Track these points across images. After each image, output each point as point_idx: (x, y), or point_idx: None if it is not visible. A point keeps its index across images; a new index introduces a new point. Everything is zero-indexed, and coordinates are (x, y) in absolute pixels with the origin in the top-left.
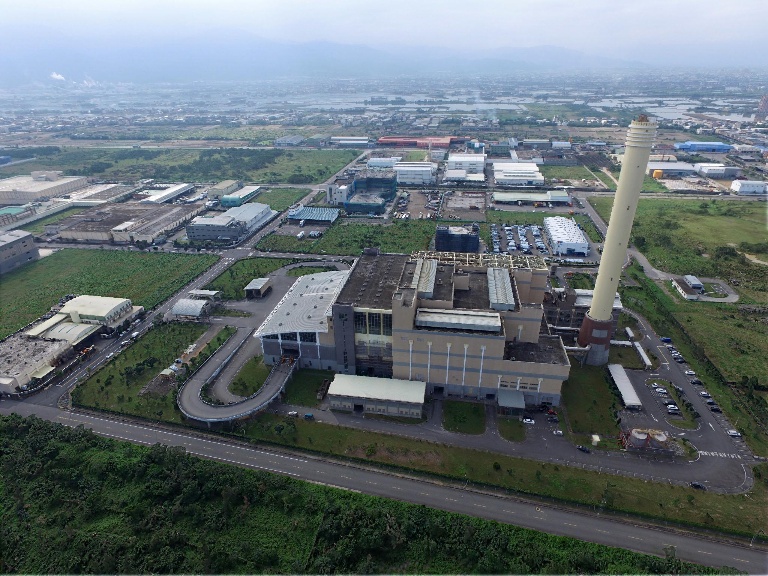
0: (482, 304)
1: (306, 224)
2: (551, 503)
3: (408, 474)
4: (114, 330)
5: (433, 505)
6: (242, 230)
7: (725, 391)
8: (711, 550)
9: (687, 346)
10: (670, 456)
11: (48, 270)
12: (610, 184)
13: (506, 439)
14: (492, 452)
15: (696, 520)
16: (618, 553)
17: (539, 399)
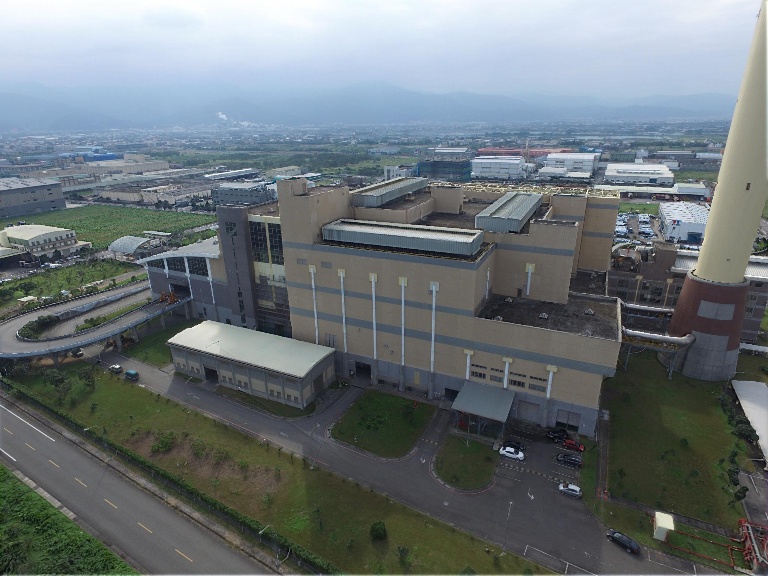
0: (466, 226)
1: None
2: None
3: (190, 503)
4: (38, 259)
5: None
6: (267, 197)
7: None
8: None
9: None
10: None
11: (57, 216)
12: None
13: (441, 478)
14: (393, 498)
15: None
16: None
17: (550, 414)
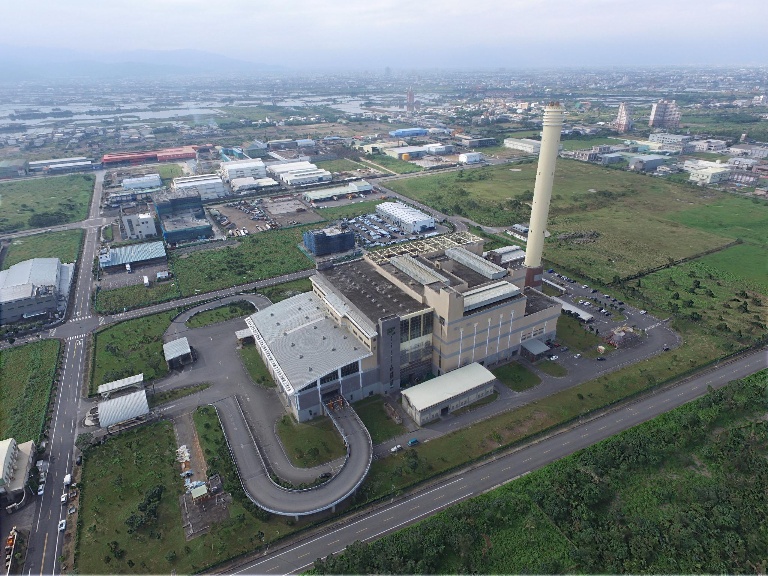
0: (479, 279)
1: (133, 268)
2: (629, 401)
3: (540, 437)
4: (22, 492)
5: (581, 447)
6: (56, 297)
7: (611, 290)
8: (709, 379)
9: (564, 271)
10: (637, 340)
11: None
12: (381, 170)
13: (558, 377)
14: (563, 390)
15: (688, 368)
16: (688, 407)
17: (544, 339)
